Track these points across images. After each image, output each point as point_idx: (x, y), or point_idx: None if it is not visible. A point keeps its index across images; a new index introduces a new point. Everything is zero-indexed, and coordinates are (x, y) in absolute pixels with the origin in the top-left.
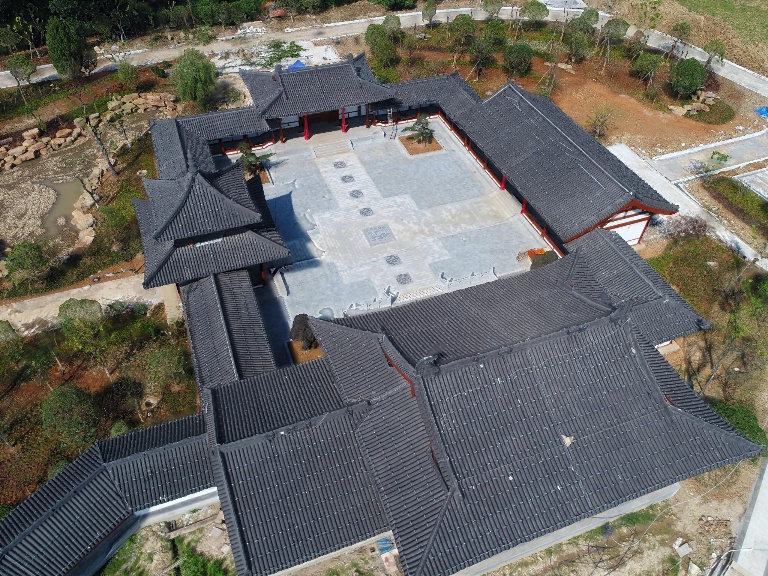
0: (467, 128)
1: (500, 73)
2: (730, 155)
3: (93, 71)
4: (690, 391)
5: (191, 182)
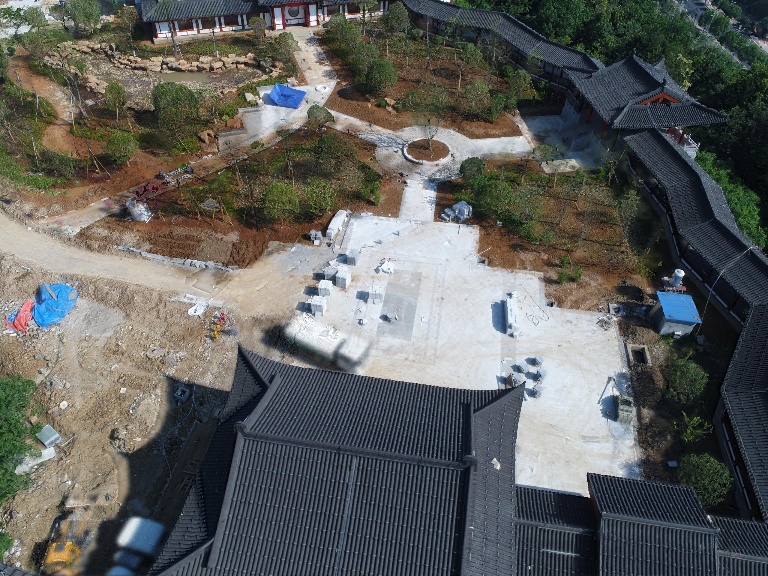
0: None
1: None
2: None
3: None
4: None
5: None
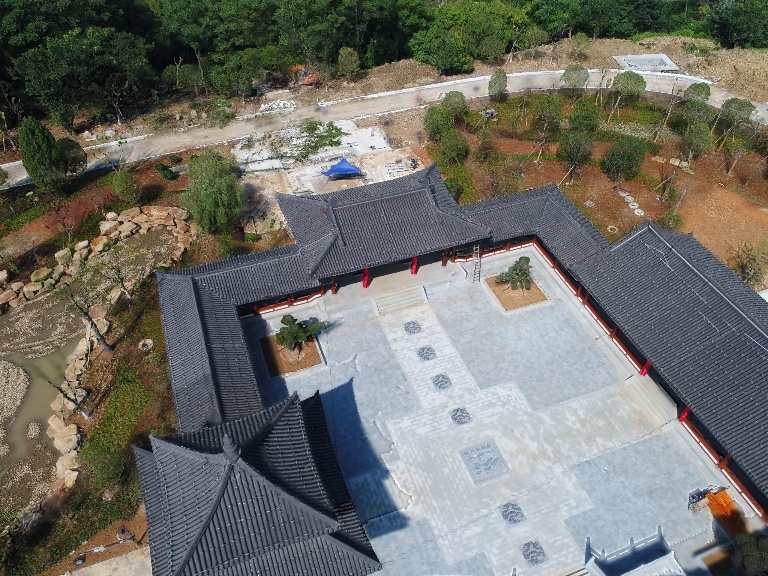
0: (593, 288)
1: (598, 172)
2: None
3: None
4: None
5: (228, 472)
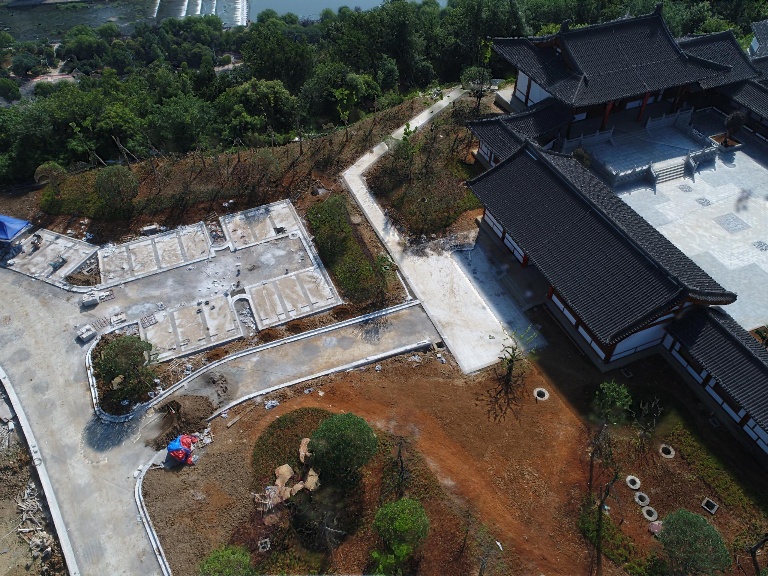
0: (709, 277)
1: None
2: (318, 353)
3: None
4: (511, 59)
5: None
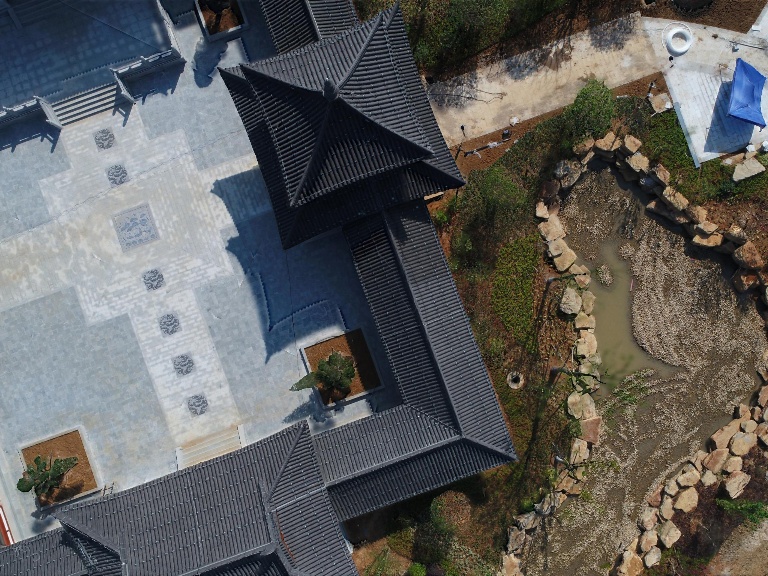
0: None
1: None
2: None
3: None
4: None
5: None
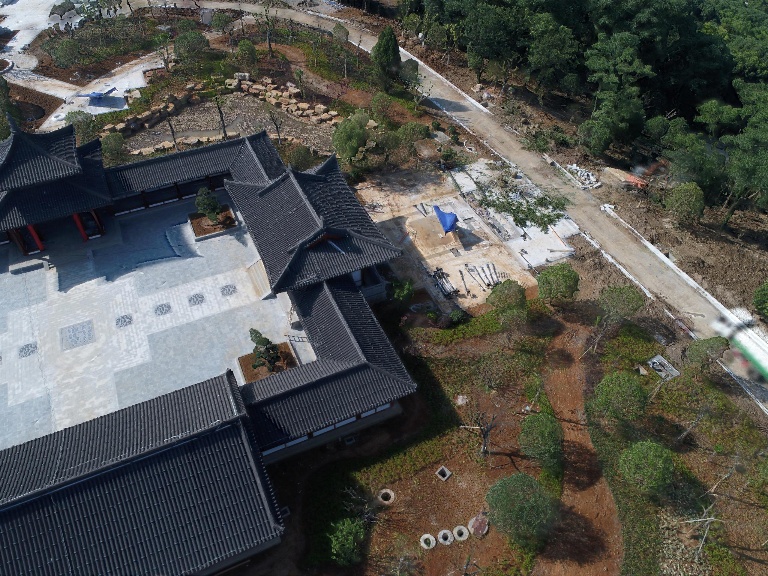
0: (194, 387)
1: None
2: None
3: (431, 95)
4: None
5: None
